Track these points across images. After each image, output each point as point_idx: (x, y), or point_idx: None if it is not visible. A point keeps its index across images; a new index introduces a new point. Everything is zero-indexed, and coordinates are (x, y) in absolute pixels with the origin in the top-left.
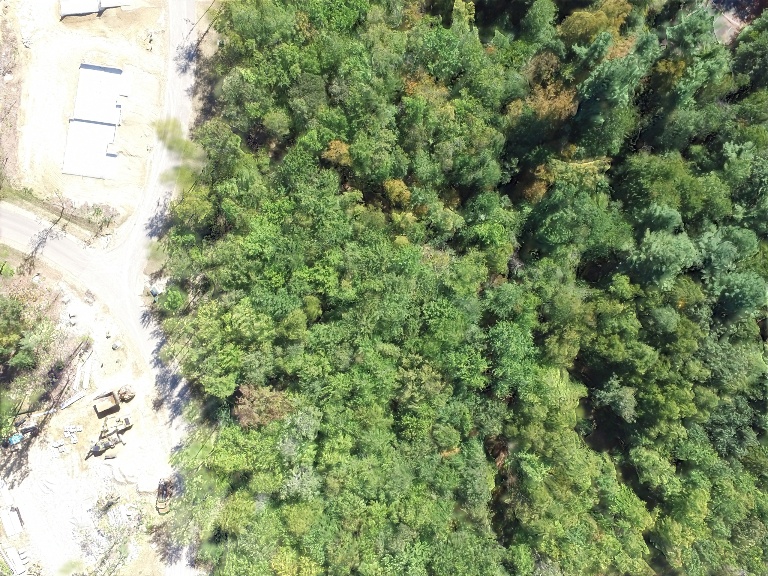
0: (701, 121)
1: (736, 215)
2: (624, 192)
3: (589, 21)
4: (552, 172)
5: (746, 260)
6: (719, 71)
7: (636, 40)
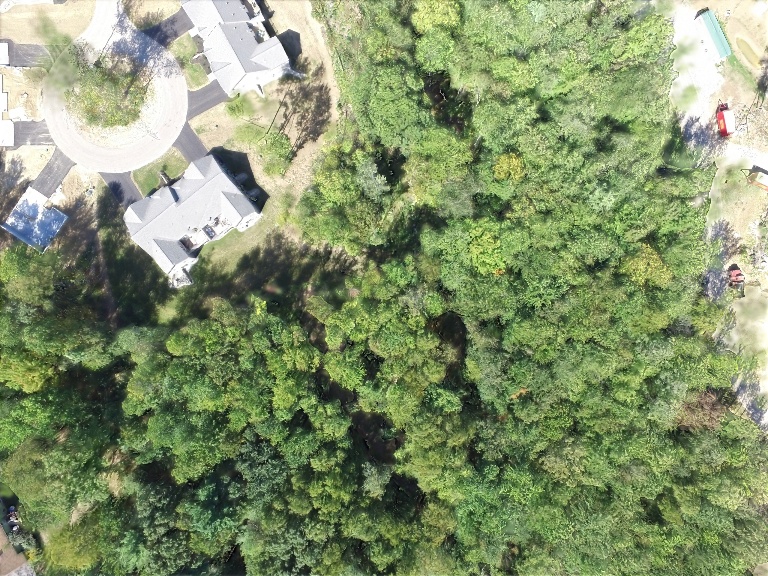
0: None
1: None
2: None
3: None
4: None
5: None
6: None
7: None
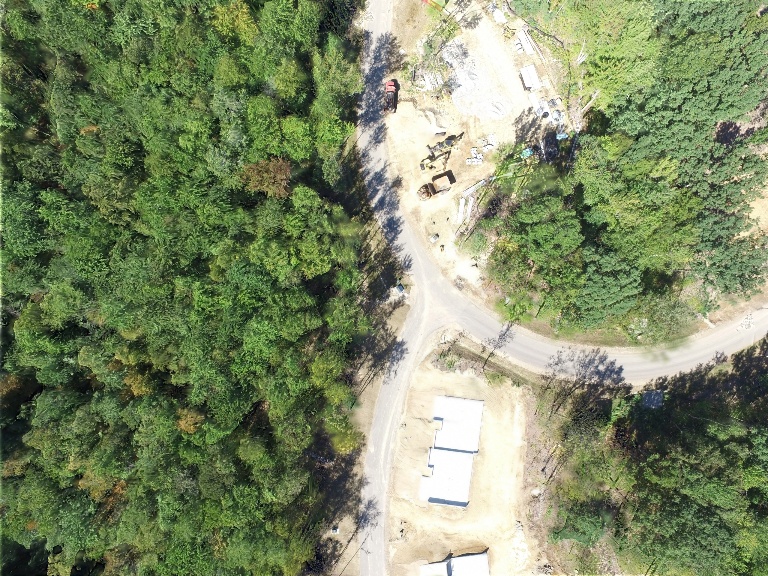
0: None
1: None
2: None
3: None
4: None
5: None
6: None
7: None
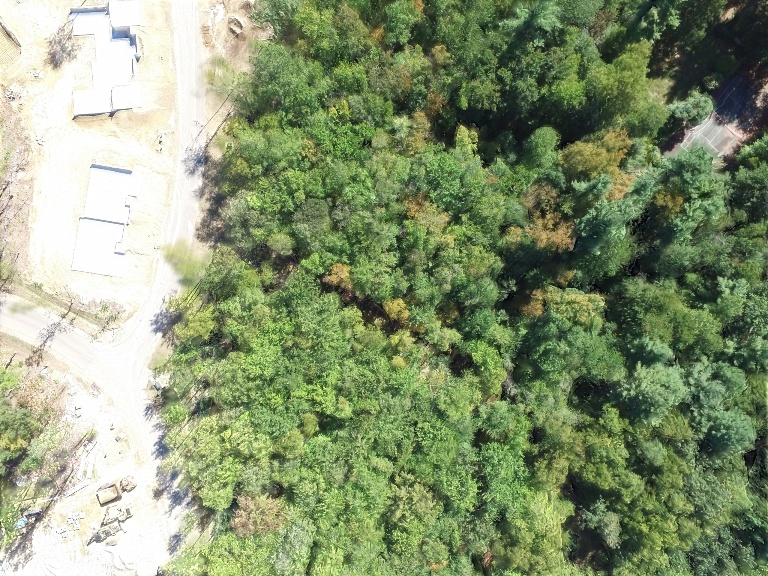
0: (696, 256)
1: (727, 349)
2: (619, 314)
3: (589, 159)
4: (548, 296)
5: (734, 396)
6: (716, 212)
7: (635, 181)
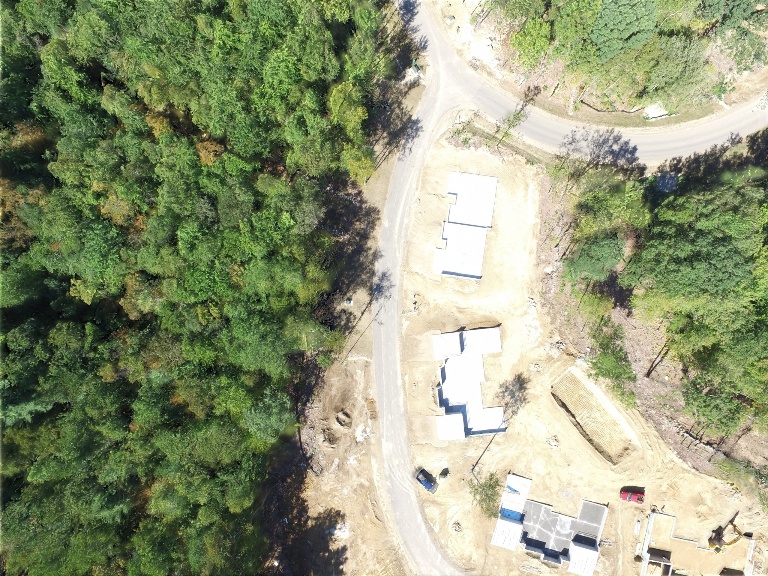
0: None
1: None
2: None
3: None
4: (6, 141)
5: None
6: None
7: None
